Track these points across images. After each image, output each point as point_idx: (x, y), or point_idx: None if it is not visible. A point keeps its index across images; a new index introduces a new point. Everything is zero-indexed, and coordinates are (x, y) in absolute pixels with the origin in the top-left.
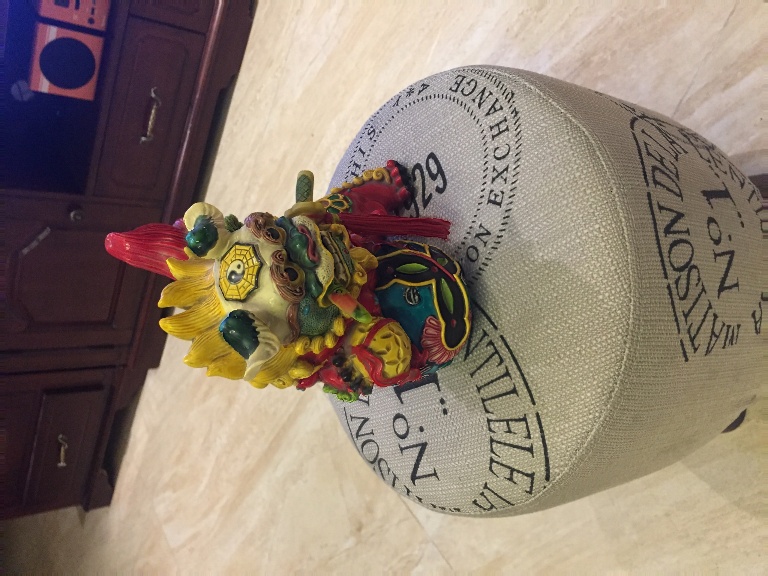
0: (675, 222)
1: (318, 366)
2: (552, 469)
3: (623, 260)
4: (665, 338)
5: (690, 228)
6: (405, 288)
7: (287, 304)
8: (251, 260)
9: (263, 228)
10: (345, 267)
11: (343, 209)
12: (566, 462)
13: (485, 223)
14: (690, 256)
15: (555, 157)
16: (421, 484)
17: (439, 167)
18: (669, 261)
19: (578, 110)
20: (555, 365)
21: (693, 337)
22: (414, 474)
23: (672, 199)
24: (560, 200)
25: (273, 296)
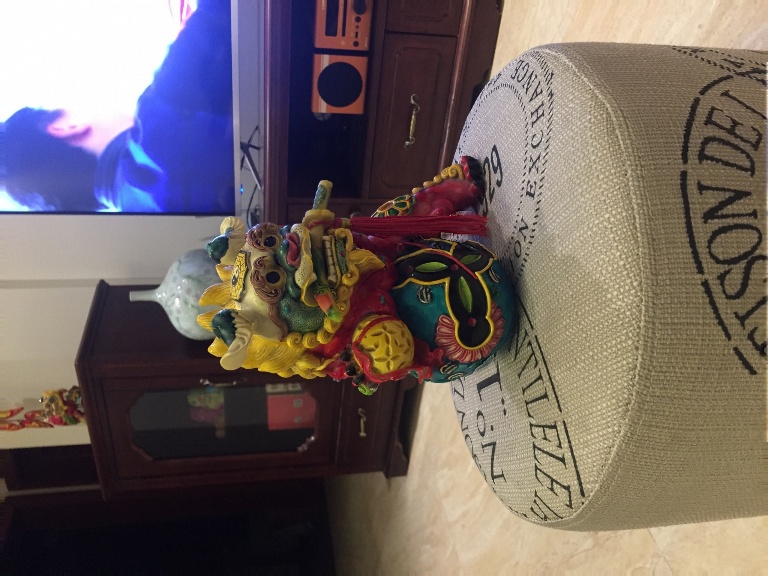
0: (728, 204)
1: (329, 359)
2: (584, 484)
3: (633, 253)
4: (701, 345)
5: (760, 209)
6: (419, 287)
7: (267, 304)
8: (242, 266)
9: (258, 237)
10: (336, 269)
11: (403, 210)
12: (595, 478)
13: (524, 216)
14: (754, 244)
15: (575, 141)
16: (497, 484)
17: (498, 160)
18: (708, 252)
19: (611, 83)
20: (573, 370)
21: (762, 345)
22: (492, 473)
23: (730, 175)
24: (576, 188)
25: (254, 297)
